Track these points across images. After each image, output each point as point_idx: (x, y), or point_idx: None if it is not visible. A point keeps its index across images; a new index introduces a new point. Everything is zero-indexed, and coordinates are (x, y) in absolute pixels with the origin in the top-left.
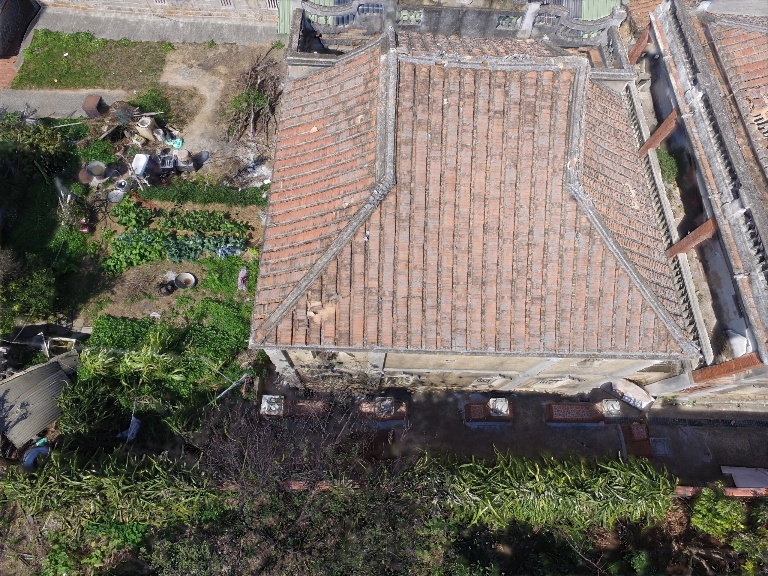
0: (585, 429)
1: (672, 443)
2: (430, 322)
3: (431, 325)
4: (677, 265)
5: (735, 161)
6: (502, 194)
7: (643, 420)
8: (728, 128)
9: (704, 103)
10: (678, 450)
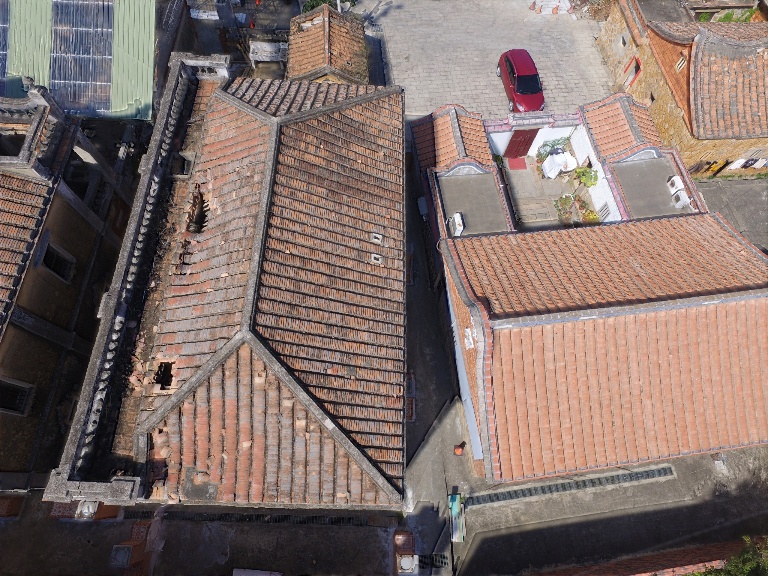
0: (99, 525)
1: (190, 541)
2: None
3: None
4: None
5: (120, 260)
6: None
7: (168, 514)
8: (132, 221)
9: (159, 186)
10: (193, 550)
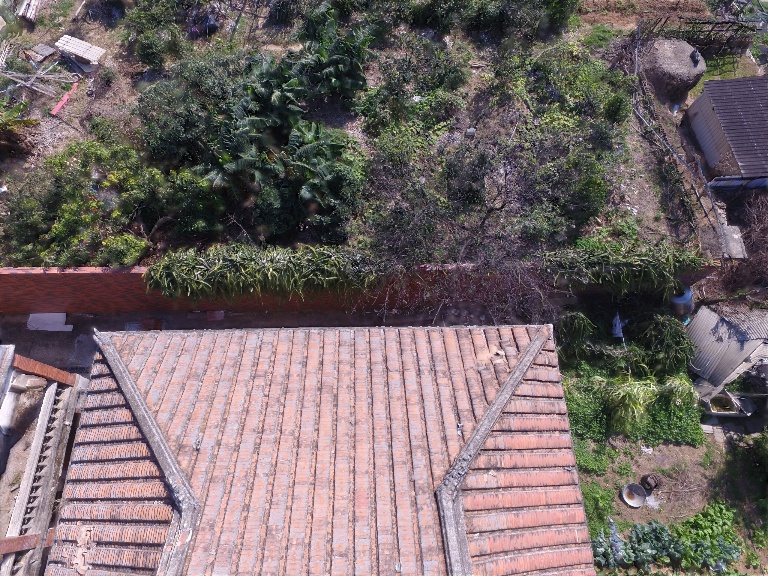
0: None
1: None
2: (378, 350)
3: (376, 348)
4: (25, 522)
5: None
6: (291, 492)
7: None
8: None
9: None
10: None
